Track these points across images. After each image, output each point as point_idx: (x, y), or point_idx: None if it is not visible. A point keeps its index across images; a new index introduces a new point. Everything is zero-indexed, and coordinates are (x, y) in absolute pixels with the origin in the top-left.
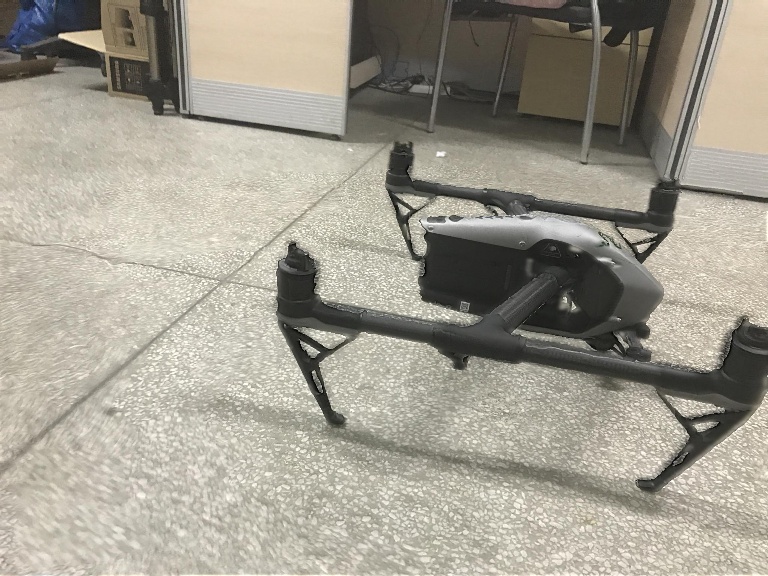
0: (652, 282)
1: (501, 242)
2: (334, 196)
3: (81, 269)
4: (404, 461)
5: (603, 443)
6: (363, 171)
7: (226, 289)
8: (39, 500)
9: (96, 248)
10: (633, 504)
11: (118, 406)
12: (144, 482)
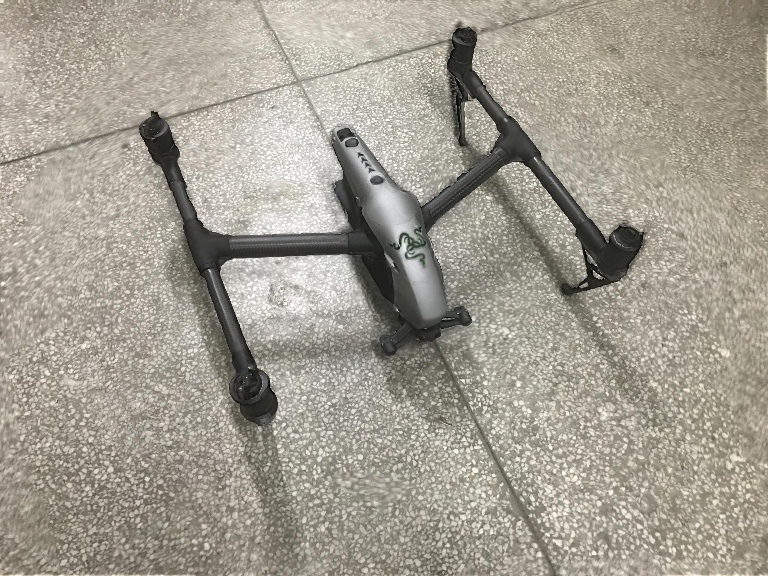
0: (417, 304)
1: (353, 186)
2: (527, 26)
3: (239, 23)
4: (187, 281)
5: (295, 371)
6: (623, 1)
7: (290, 90)
8: (49, 175)
9: (273, 5)
10: (239, 409)
11: (132, 144)
12: (86, 197)
